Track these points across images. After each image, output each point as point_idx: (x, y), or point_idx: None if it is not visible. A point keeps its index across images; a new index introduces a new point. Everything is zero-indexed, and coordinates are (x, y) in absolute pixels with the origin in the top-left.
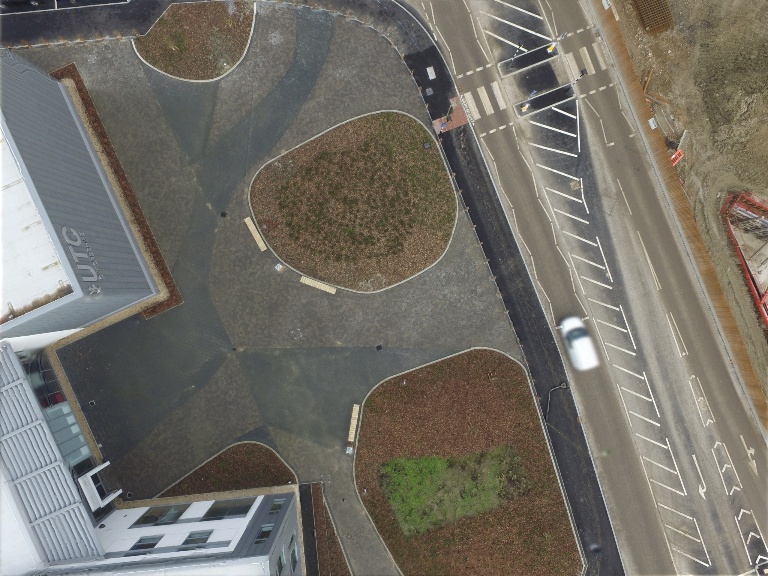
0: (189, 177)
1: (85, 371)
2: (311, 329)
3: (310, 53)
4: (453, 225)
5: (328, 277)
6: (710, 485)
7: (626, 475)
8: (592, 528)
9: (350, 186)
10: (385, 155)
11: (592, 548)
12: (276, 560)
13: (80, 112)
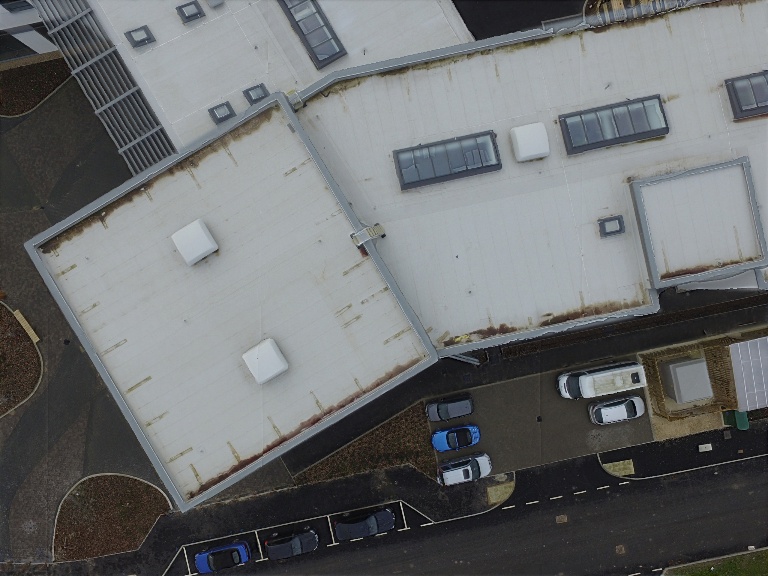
0: None
1: None
2: None
3: None
4: None
5: None
6: None
7: None
8: None
9: None
10: None
11: None
12: None
13: None
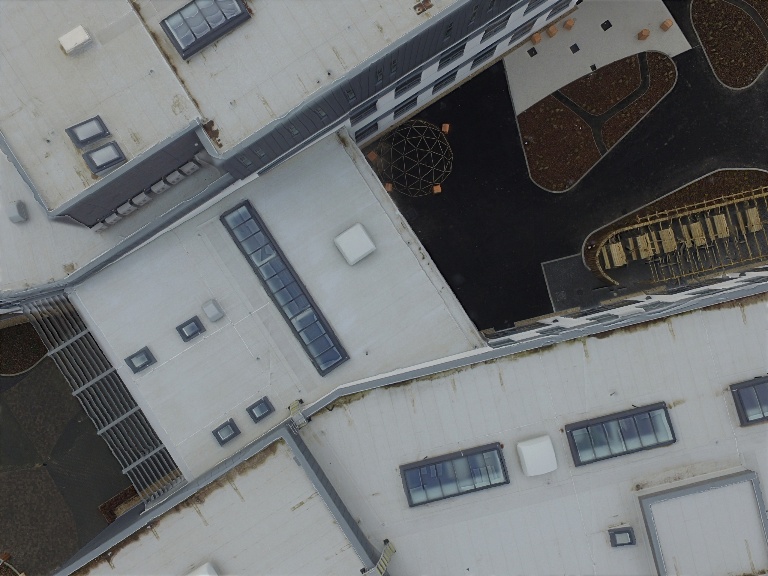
0: None
1: None
2: None
3: None
4: None
5: None
6: None
7: None
8: None
9: None
10: None
11: None
12: None
13: None
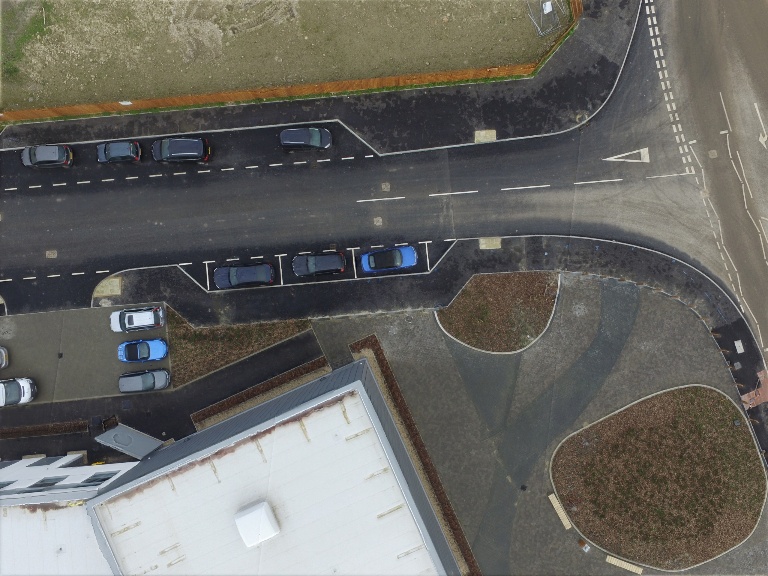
0: (489, 450)
1: None
2: None
3: (615, 325)
4: (762, 503)
5: (633, 555)
6: None
7: None
8: None
9: (658, 464)
10: (694, 433)
11: None
12: None
13: (379, 383)
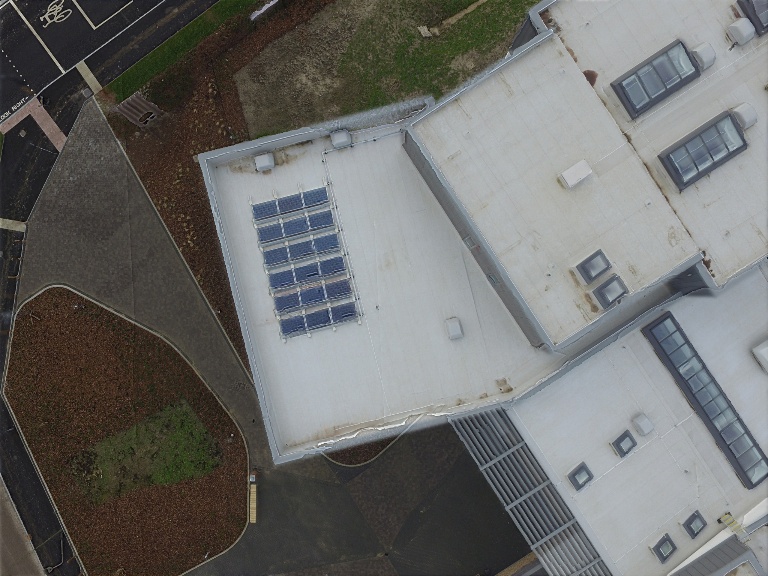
0: None
1: None
2: None
3: None
4: None
5: None
6: None
7: None
8: (1, 431)
9: None
10: None
11: None
12: None
13: None
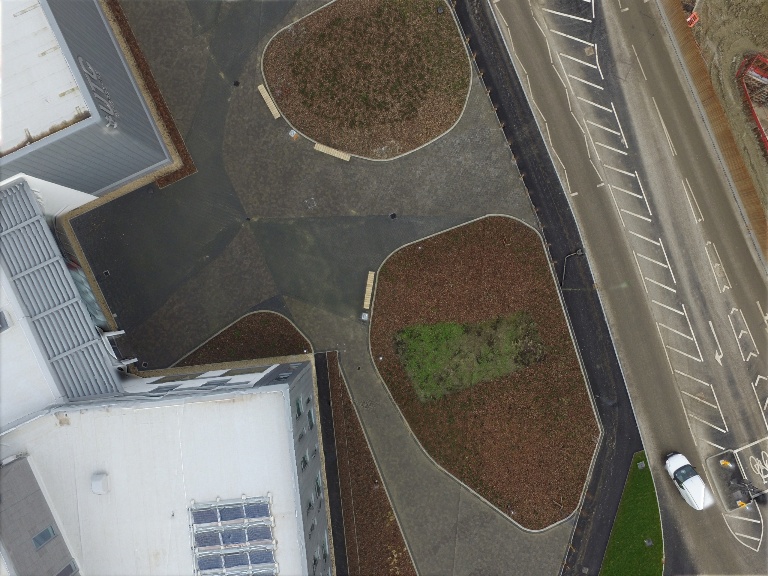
0: (201, 46)
1: (99, 241)
2: (325, 198)
3: None
4: (467, 91)
5: (342, 145)
6: (727, 351)
7: (642, 342)
8: (608, 395)
9: (363, 52)
10: (398, 20)
11: (609, 415)
12: (295, 398)
13: None
